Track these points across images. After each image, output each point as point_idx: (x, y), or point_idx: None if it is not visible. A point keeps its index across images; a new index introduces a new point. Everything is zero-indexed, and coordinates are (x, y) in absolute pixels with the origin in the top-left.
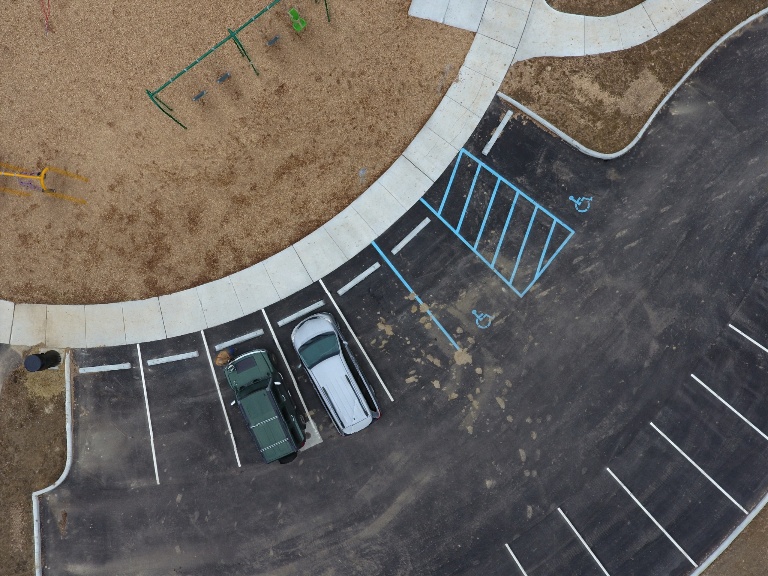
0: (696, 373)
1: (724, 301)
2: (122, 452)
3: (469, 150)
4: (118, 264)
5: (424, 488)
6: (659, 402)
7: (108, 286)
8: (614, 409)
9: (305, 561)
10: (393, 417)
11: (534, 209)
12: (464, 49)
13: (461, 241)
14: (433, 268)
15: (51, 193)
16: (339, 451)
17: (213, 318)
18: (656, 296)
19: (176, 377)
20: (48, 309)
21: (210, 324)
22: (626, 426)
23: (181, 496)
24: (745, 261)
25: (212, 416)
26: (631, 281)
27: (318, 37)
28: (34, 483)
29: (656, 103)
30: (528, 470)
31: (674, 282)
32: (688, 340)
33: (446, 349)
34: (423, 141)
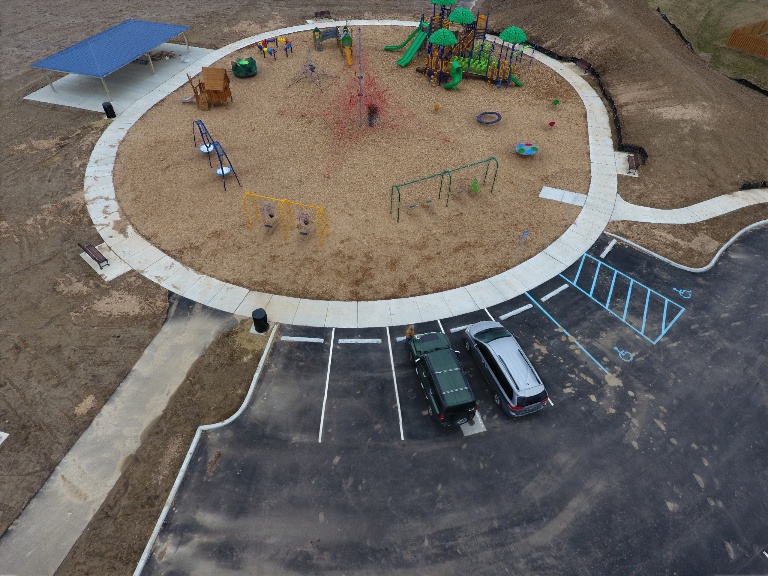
0: None
1: None
2: (294, 406)
3: (590, 254)
4: (334, 279)
5: (597, 497)
6: None
7: (322, 290)
8: None
9: (465, 561)
10: (555, 419)
11: (648, 291)
12: (577, 212)
13: (595, 301)
14: (575, 314)
15: (301, 239)
16: (503, 442)
17: (398, 320)
18: None
19: (359, 355)
20: (273, 297)
21: (395, 324)
22: None
23: (339, 458)
24: None
25: (384, 390)
26: (748, 347)
27: (484, 198)
28: (204, 418)
29: (717, 249)
30: (711, 498)
31: None
32: None
33: (596, 371)
34: (557, 247)
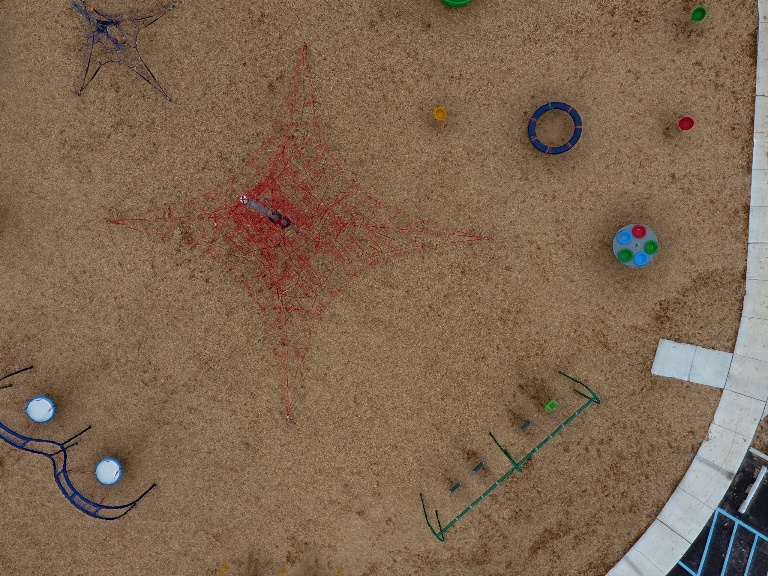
0: None
1: None
2: None
3: (725, 509)
4: None
5: None
6: None
7: None
8: None
9: None
10: None
11: None
12: (713, 407)
13: None
14: None
15: None
16: None
17: None
18: None
19: None
20: None
21: None
22: None
23: None
24: None
25: None
26: None
27: (563, 406)
28: None
29: None
30: None
31: None
32: None
33: None
34: (677, 503)
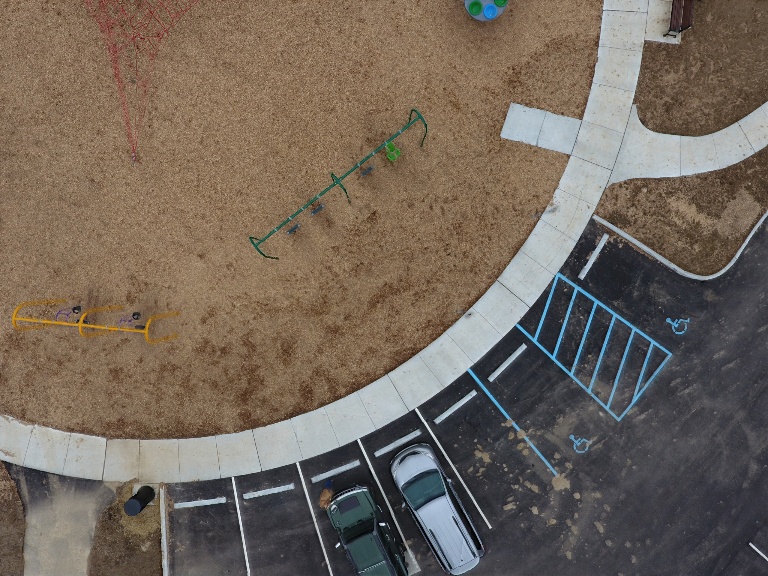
0: None
1: None
2: None
3: (565, 274)
4: (211, 397)
5: None
6: (758, 522)
7: (201, 420)
8: (713, 530)
9: None
10: (491, 544)
11: (631, 332)
12: (558, 172)
13: (558, 366)
14: (530, 394)
15: None
16: None
17: (308, 450)
18: (754, 416)
19: (272, 510)
20: (141, 444)
21: (305, 456)
22: (725, 547)
23: None
24: None
25: (309, 548)
26: (729, 402)
27: (410, 163)
28: None
29: (753, 223)
30: None
31: None
32: None
33: (544, 475)
34: (518, 266)
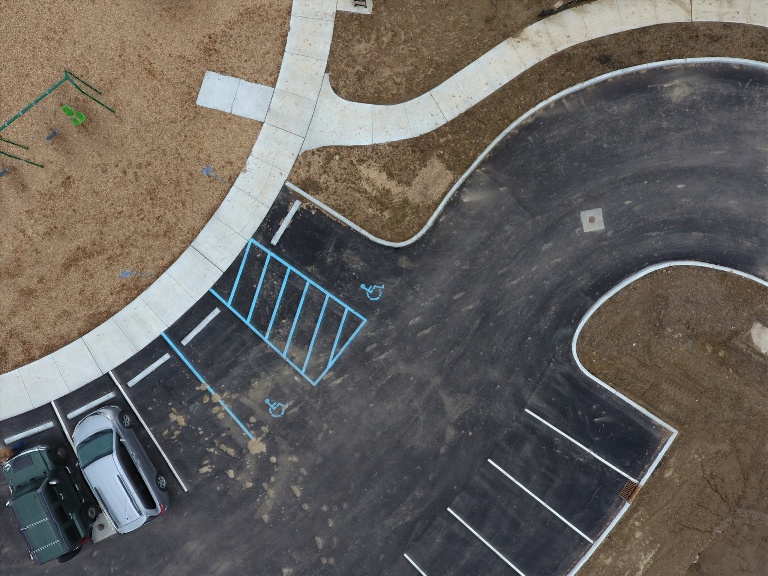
0: (493, 458)
1: (520, 386)
2: None
3: (258, 240)
4: None
5: None
6: (456, 487)
7: None
8: (410, 495)
9: None
10: (187, 507)
11: (325, 298)
12: (251, 139)
13: (252, 331)
14: (224, 358)
15: None
16: (133, 542)
17: (2, 411)
18: (451, 382)
19: None
20: None
21: None
22: (423, 512)
23: None
24: (540, 346)
25: (3, 509)
26: (425, 368)
27: (104, 128)
28: None
29: (446, 191)
30: (324, 557)
31: (469, 368)
32: (484, 425)
33: (239, 438)
34: (212, 231)
